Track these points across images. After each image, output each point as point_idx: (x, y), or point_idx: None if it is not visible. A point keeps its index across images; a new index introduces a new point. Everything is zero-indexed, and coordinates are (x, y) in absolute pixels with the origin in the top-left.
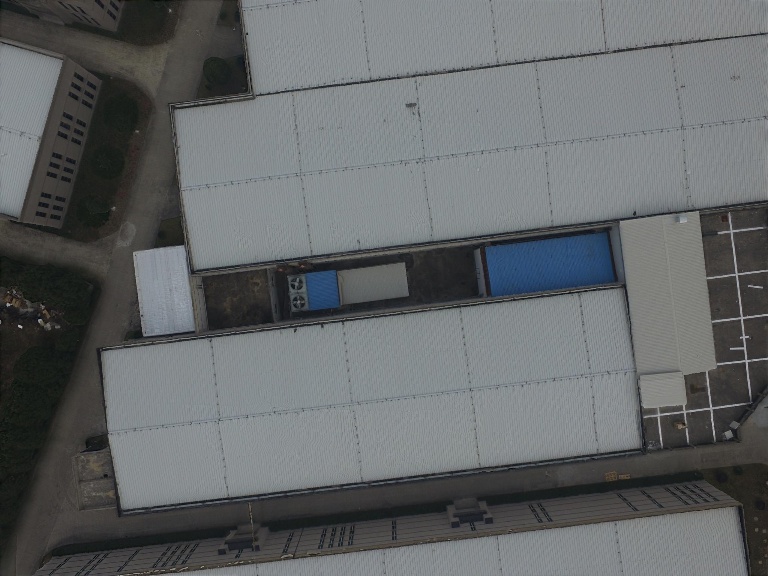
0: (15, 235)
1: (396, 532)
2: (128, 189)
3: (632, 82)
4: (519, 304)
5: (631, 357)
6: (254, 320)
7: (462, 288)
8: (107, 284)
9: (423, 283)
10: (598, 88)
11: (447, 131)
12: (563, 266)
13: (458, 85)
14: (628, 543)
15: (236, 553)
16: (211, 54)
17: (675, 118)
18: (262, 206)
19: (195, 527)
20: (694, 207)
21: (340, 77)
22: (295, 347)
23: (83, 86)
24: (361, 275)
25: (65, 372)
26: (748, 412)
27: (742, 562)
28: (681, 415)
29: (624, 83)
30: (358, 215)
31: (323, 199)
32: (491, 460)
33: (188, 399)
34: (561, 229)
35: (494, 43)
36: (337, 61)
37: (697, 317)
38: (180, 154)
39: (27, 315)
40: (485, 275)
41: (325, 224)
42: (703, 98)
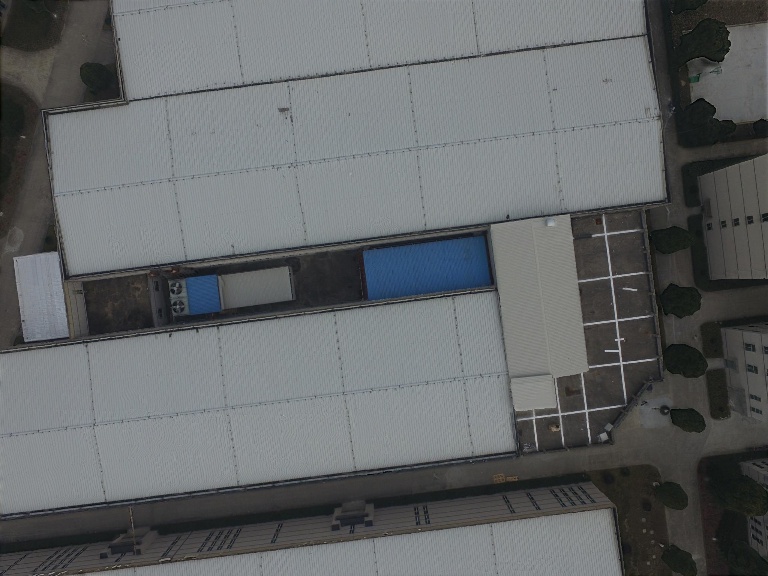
0: None
1: (278, 535)
2: (15, 194)
3: (504, 85)
4: (393, 308)
5: (504, 360)
6: (135, 325)
7: (349, 291)
8: None
9: (310, 287)
10: (470, 92)
11: (319, 135)
12: (440, 269)
13: (331, 89)
14: (503, 545)
15: (118, 557)
16: (97, 59)
17: (547, 121)
18: (135, 211)
19: (86, 531)
20: (567, 210)
21: (213, 82)
22: (170, 352)
23: None
24: (242, 279)
25: None
26: (622, 414)
27: (617, 564)
28: (556, 417)
29: (496, 86)
30: (229, 220)
31: (196, 204)
32: (369, 463)
33: (64, 404)
34: (433, 233)
35: (366, 47)
36: (210, 66)
37: (568, 320)
38: (53, 160)
39: None
40: (362, 279)
41: (199, 229)
42: (575, 101)
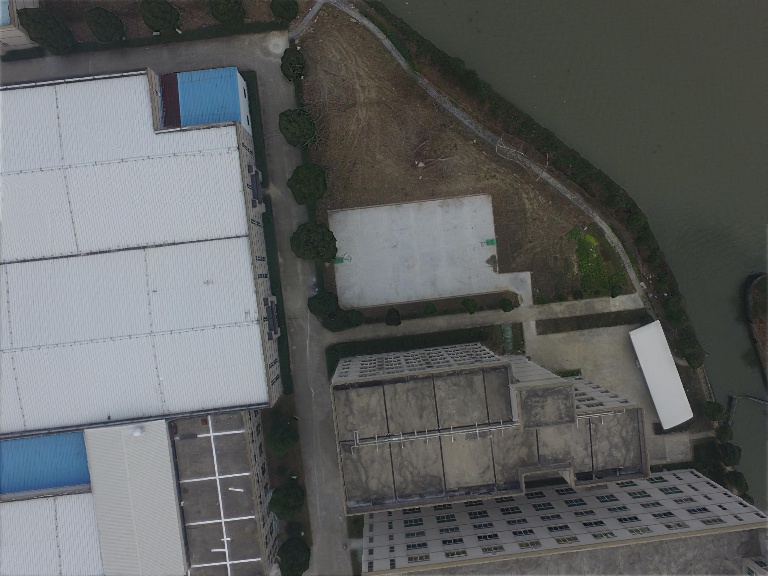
0: None
1: None
2: None
3: (103, 286)
4: None
5: None
6: None
7: None
8: None
9: None
10: (68, 292)
11: None
12: (51, 465)
13: None
14: None
15: None
16: None
17: (145, 324)
18: None
19: None
20: (169, 412)
21: None
22: None
23: None
24: None
25: None
26: None
27: None
28: None
29: (95, 287)
30: None
31: None
32: None
33: None
34: (28, 436)
35: None
36: None
37: (162, 526)
38: None
39: None
40: None
41: None
42: (174, 303)
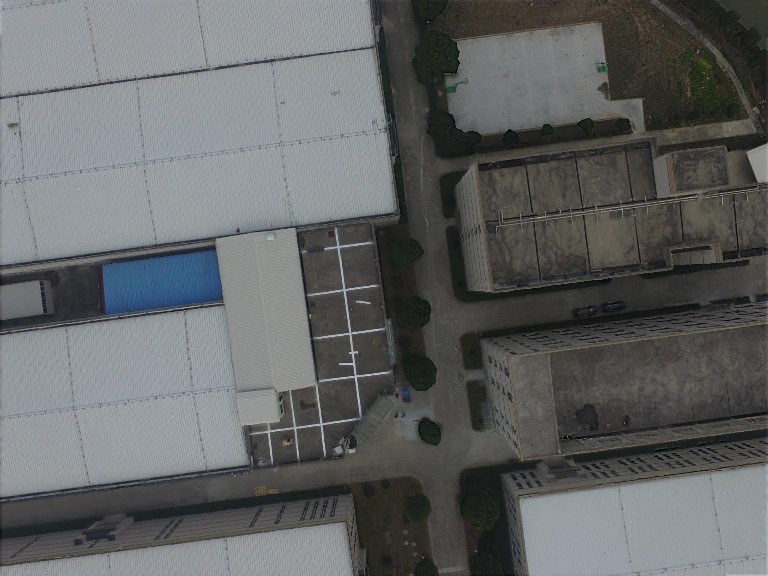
0: None
1: (24, 549)
2: None
3: (232, 99)
4: (125, 322)
5: None
6: None
7: None
8: None
9: (69, 300)
10: (198, 105)
11: (47, 150)
12: (178, 283)
13: (60, 104)
14: (238, 559)
15: None
16: None
17: (274, 134)
18: None
19: None
20: (298, 223)
21: None
22: None
23: None
24: None
25: None
26: None
27: None
28: (291, 431)
29: (224, 100)
30: None
31: None
32: (107, 478)
33: None
34: (160, 247)
35: (95, 62)
36: None
37: (293, 334)
38: None
39: None
40: (100, 293)
41: None
42: (302, 114)
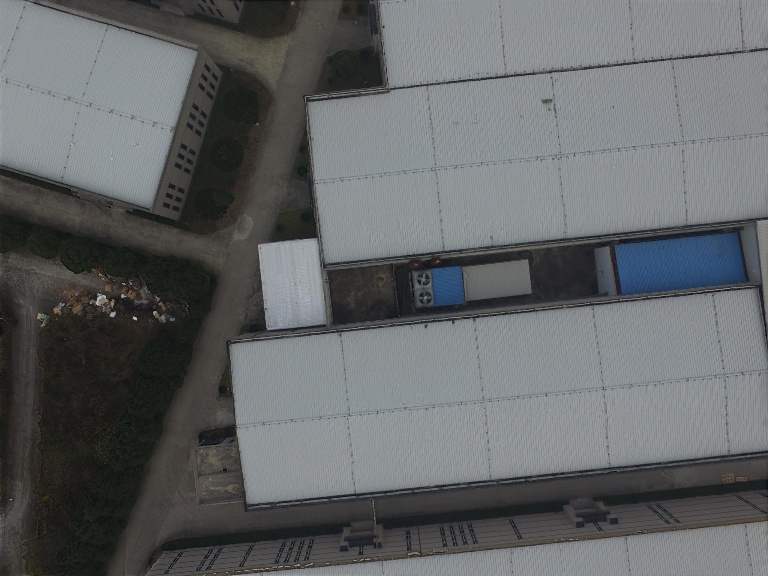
0: (131, 226)
1: (519, 531)
2: (246, 182)
3: None
4: (652, 303)
5: (765, 358)
6: (378, 315)
7: (581, 286)
8: (223, 277)
9: (542, 281)
10: (735, 87)
11: (583, 128)
12: (693, 265)
13: (594, 82)
14: (758, 546)
15: (358, 550)
16: (332, 47)
17: None
18: (395, 200)
19: (307, 523)
20: None
21: (475, 72)
22: (426, 343)
23: (209, 77)
24: (486, 272)
25: (185, 365)
26: None
27: None
28: None
29: (761, 82)
30: (494, 211)
31: (457, 194)
32: (619, 460)
33: (317, 394)
34: (697, 228)
35: (631, 40)
36: (473, 56)
37: None
38: (314, 147)
39: (142, 307)
40: (615, 273)
41: (458, 219)
42: None
